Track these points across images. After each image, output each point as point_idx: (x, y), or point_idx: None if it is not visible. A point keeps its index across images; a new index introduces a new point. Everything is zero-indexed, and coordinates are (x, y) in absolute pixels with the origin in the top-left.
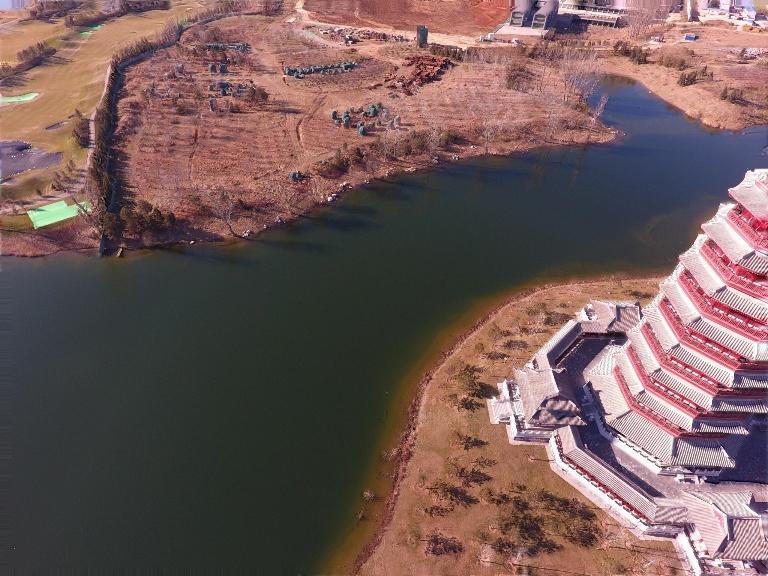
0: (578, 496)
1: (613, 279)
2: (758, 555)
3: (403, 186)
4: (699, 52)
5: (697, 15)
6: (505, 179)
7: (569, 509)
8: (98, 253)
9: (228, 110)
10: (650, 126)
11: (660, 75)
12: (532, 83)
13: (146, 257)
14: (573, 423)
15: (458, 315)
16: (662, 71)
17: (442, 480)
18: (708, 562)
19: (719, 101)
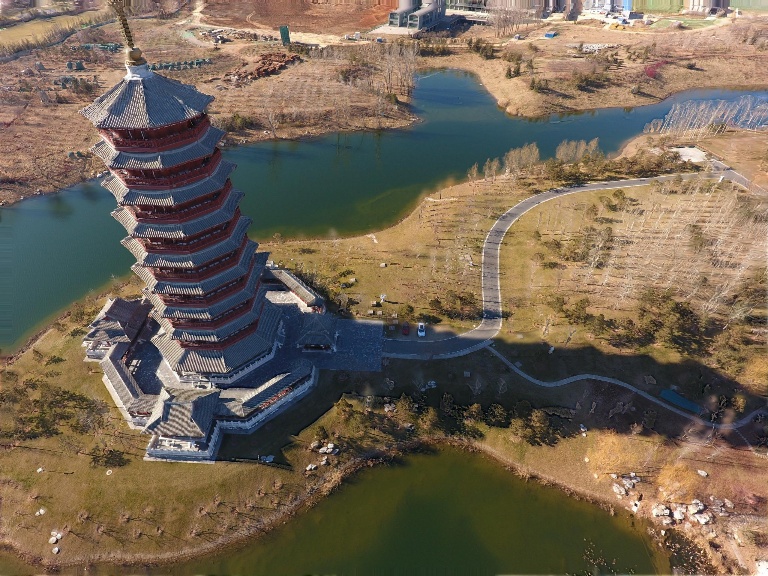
0: (106, 398)
1: (276, 236)
2: (181, 432)
3: None
4: (542, 48)
5: (578, 15)
6: (276, 159)
7: (91, 407)
8: None
9: (55, 101)
10: (454, 114)
11: (498, 69)
12: (371, 77)
13: None
14: (121, 340)
15: None
16: (502, 65)
17: (9, 387)
18: (164, 443)
19: (528, 91)
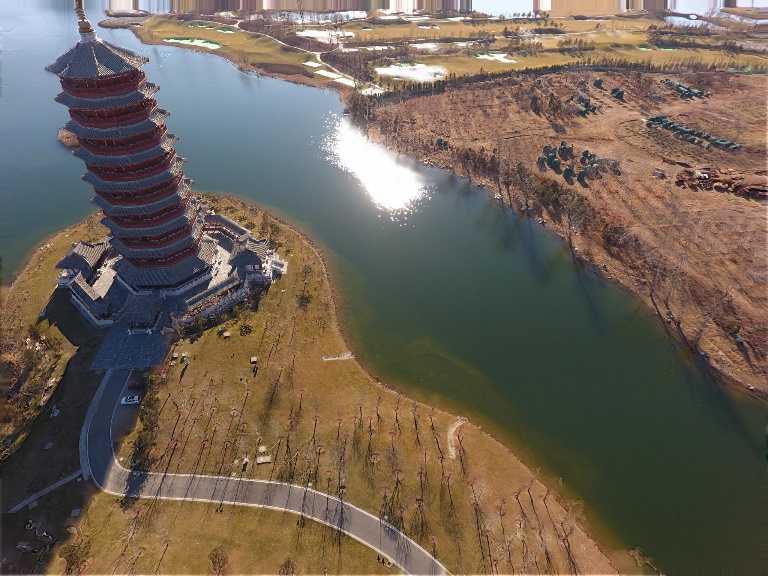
0: None
1: None
2: None
3: (464, 193)
4: None
5: None
6: (515, 253)
7: None
8: (344, 110)
9: (533, 107)
10: None
11: None
12: None
13: (344, 122)
14: None
15: (292, 215)
16: None
17: None
18: None
19: None
